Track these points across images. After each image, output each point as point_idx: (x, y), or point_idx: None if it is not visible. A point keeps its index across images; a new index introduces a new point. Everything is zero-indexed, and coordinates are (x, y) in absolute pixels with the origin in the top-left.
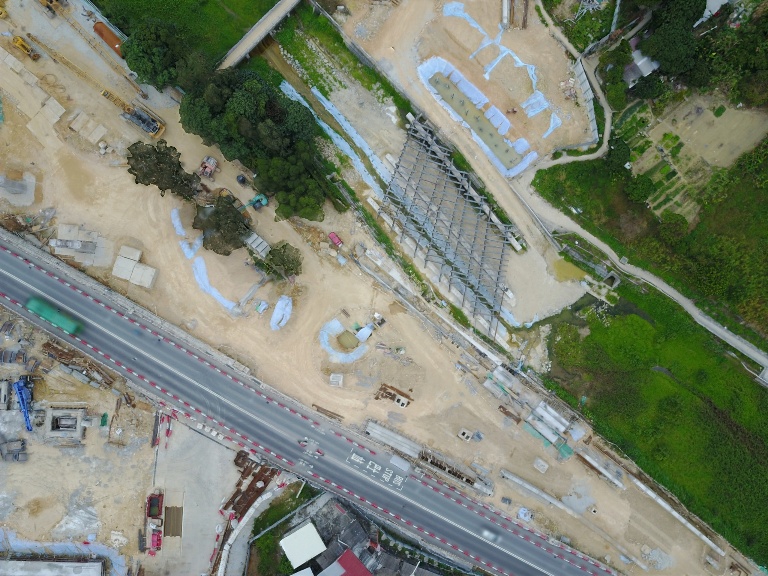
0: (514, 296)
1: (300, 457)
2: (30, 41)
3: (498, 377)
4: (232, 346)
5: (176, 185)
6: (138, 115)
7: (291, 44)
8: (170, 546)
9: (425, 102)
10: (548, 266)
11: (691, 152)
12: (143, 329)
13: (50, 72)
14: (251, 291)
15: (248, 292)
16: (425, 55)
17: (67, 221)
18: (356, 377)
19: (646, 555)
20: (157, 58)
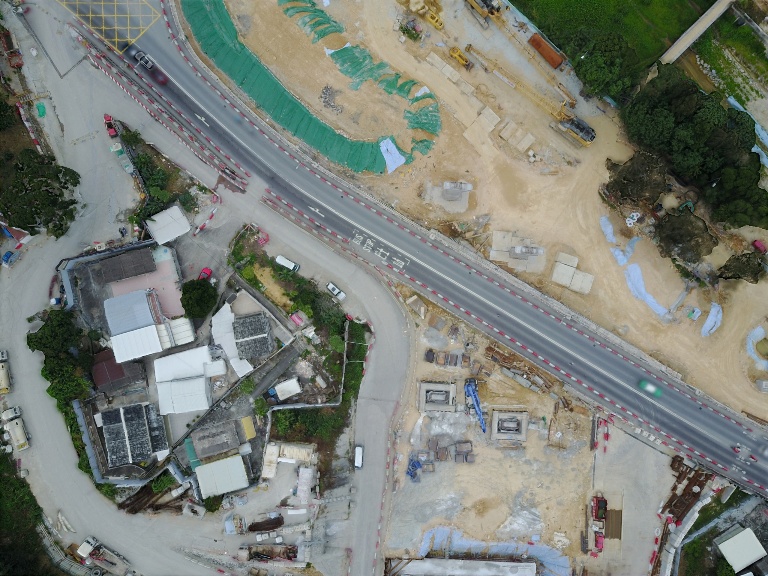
0: None
1: (733, 463)
2: (463, 52)
3: None
4: (663, 352)
5: None
6: (576, 124)
7: (709, 54)
8: (610, 548)
9: None
10: None
11: None
12: (579, 334)
13: (481, 82)
14: (680, 298)
15: (677, 299)
16: None
17: (500, 228)
18: None
19: None
20: (617, 69)
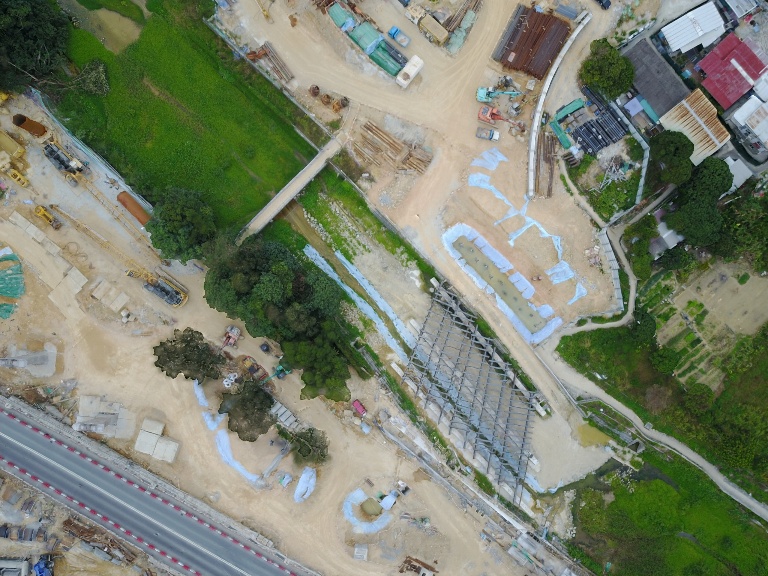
0: (539, 462)
1: None
2: (52, 209)
3: (523, 545)
4: (255, 519)
5: (203, 376)
6: (162, 287)
7: (315, 208)
8: None
9: (450, 269)
10: (572, 431)
11: (715, 319)
12: (166, 504)
13: (72, 240)
14: (275, 462)
15: (272, 463)
16: (450, 222)
17: (89, 392)
18: (380, 548)
19: None
20: (183, 238)
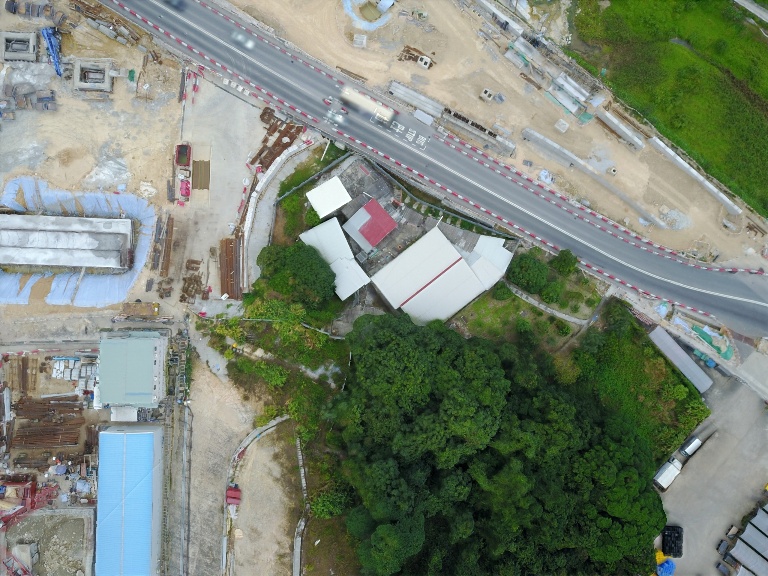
0: None
1: (325, 115)
2: None
3: (519, 47)
4: (256, 7)
5: None
6: None
7: None
8: (198, 198)
9: None
10: None
11: None
12: None
13: None
14: None
15: None
16: None
17: None
18: (379, 42)
19: (664, 215)
20: None
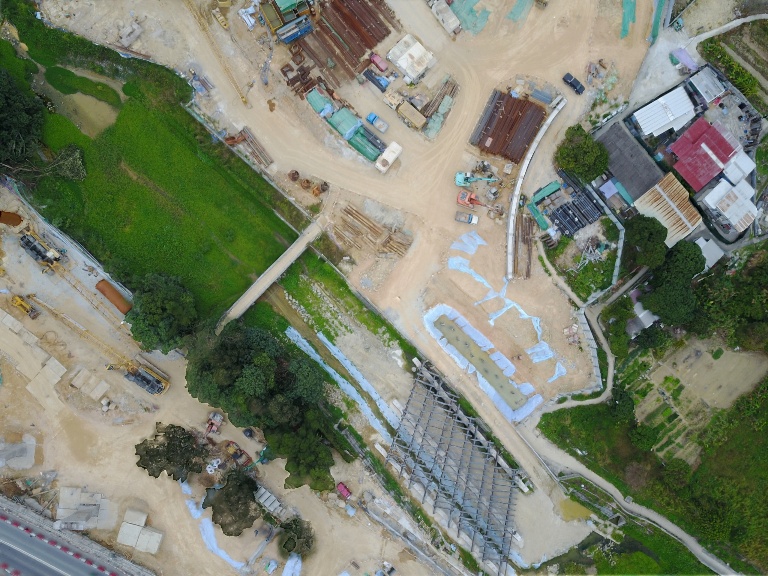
0: (522, 539)
1: None
2: None
3: None
4: None
5: (186, 475)
6: (142, 376)
7: (296, 290)
8: None
9: (431, 350)
10: (555, 506)
11: (691, 394)
12: None
13: (50, 329)
14: (259, 548)
15: (256, 550)
16: (431, 303)
17: (69, 483)
18: None
19: None
20: (163, 331)
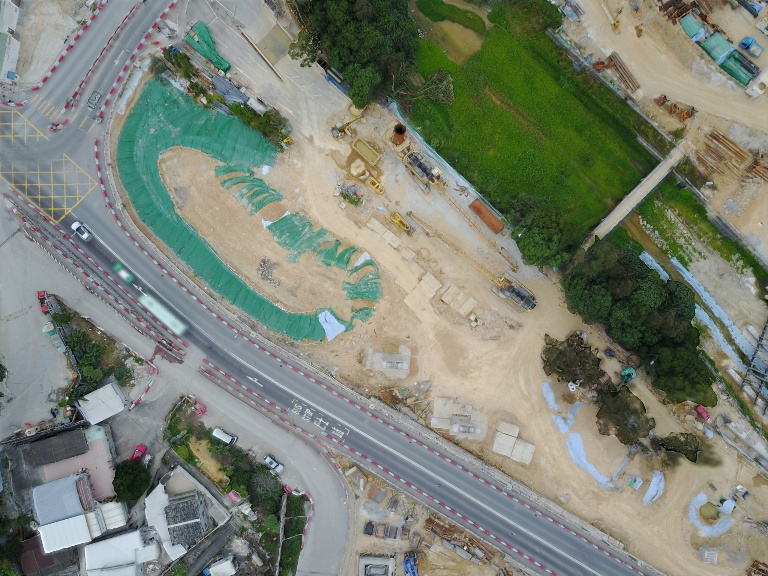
0: None
1: None
2: (405, 216)
3: None
4: (605, 521)
5: None
6: (516, 292)
7: (652, 215)
8: None
9: None
10: None
11: None
12: (521, 504)
13: (423, 246)
14: (622, 465)
15: (619, 466)
16: None
17: (442, 394)
18: (724, 552)
19: None
20: (554, 245)
